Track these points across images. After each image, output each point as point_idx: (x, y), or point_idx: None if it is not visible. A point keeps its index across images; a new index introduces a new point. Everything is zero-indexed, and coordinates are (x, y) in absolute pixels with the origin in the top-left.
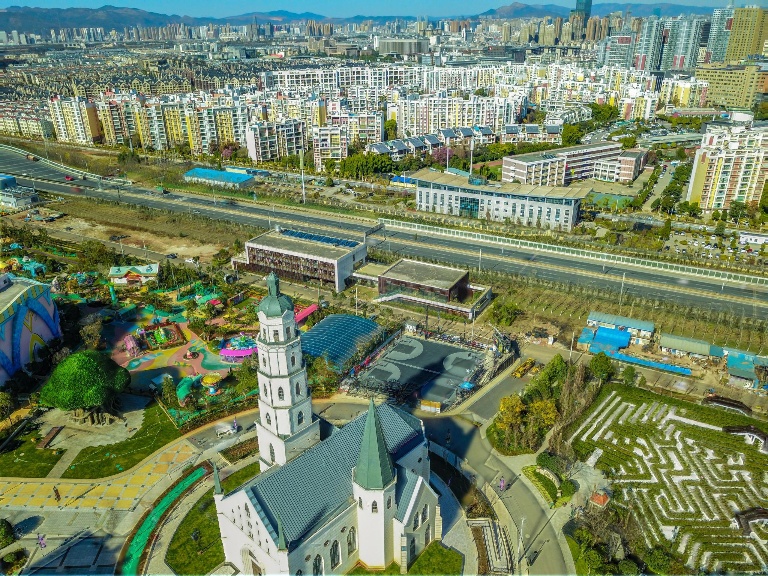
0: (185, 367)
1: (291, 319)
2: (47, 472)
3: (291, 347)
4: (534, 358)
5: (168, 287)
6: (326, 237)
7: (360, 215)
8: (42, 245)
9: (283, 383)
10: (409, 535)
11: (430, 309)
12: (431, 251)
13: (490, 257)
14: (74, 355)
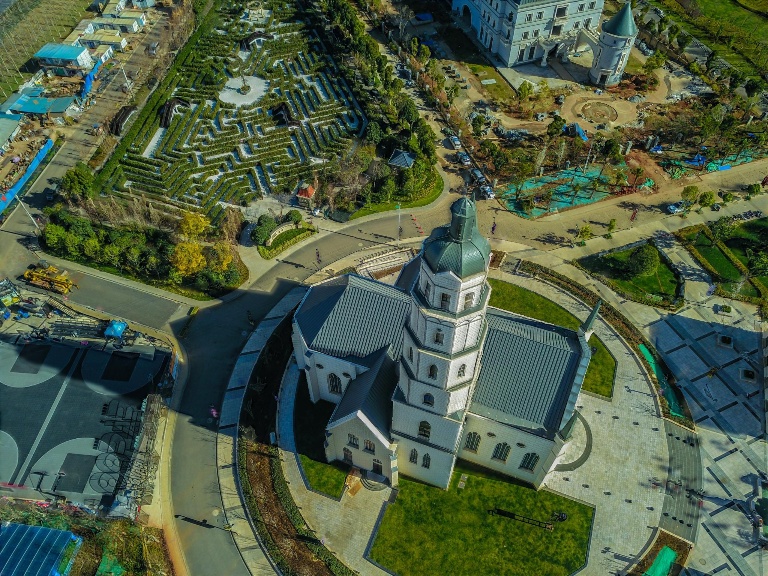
0: None
1: None
2: None
3: None
4: (12, 277)
5: None
6: None
7: None
8: None
9: None
10: None
11: None
12: None
13: None
14: None
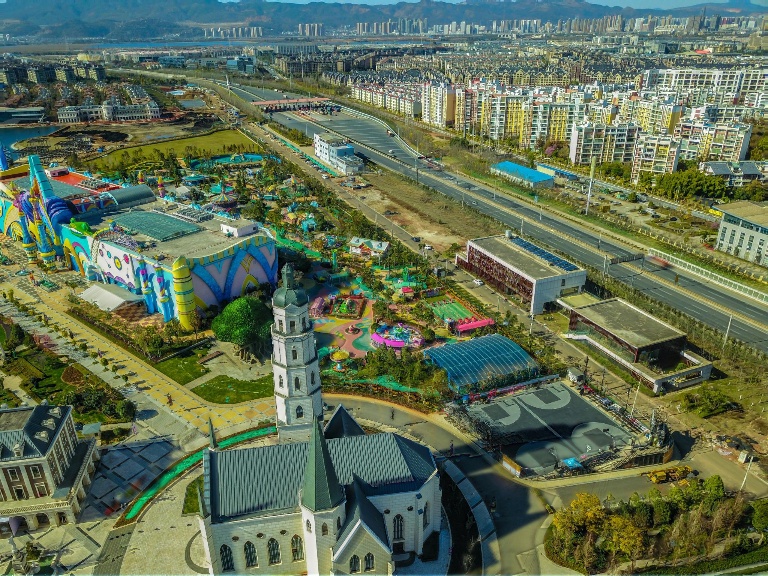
0: (340, 339)
1: (297, 314)
2: (187, 382)
3: (292, 341)
4: (700, 469)
5: (387, 265)
6: (549, 253)
7: (637, 240)
8: (331, 207)
9: (282, 372)
10: (342, 574)
11: (614, 364)
12: (687, 300)
13: (762, 328)
14: (241, 298)
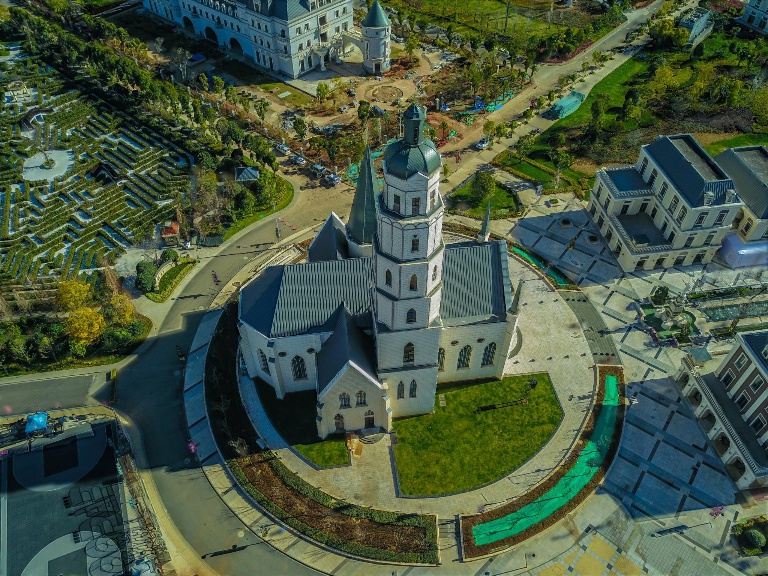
0: None
1: None
2: None
3: None
4: None
5: None
6: None
7: None
8: None
9: None
10: None
11: None
12: None
13: None
14: None
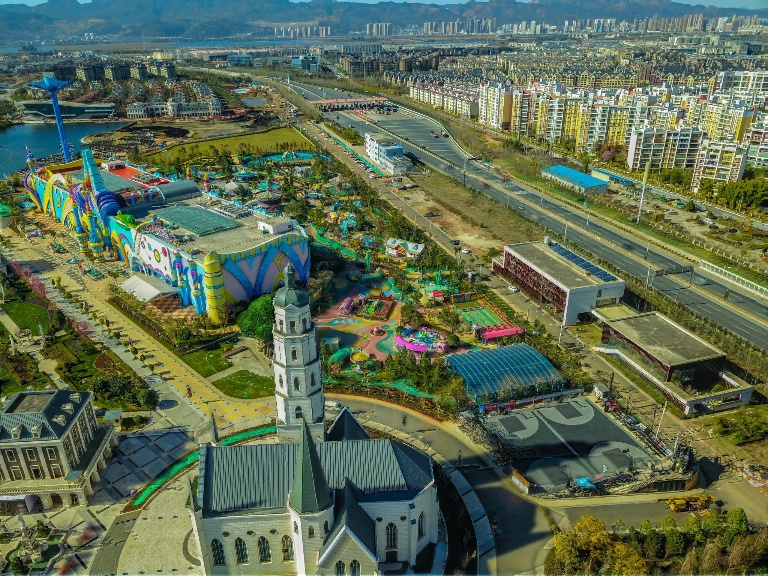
0: (364, 340)
1: (297, 315)
2: (209, 375)
3: (292, 341)
4: (726, 500)
5: None
6: (588, 262)
7: (690, 251)
8: (373, 207)
9: (282, 372)
10: None
11: (646, 381)
12: (736, 318)
13: None
14: (266, 295)
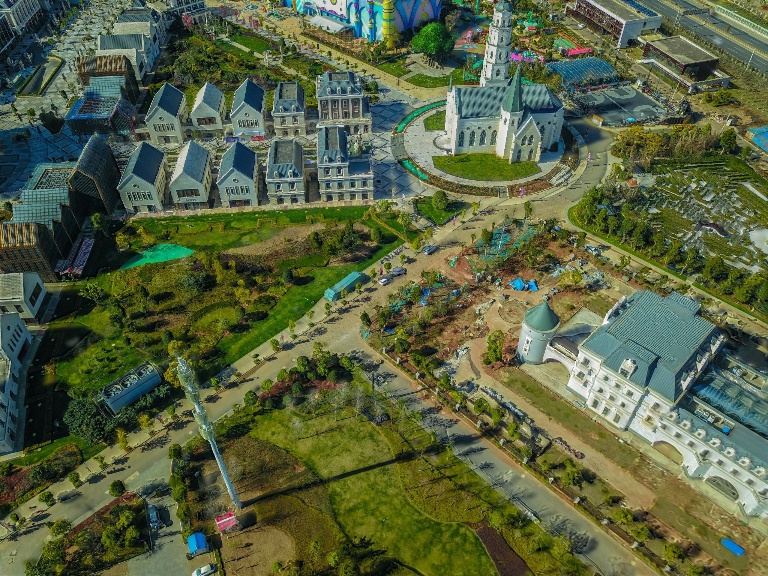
0: None
1: (507, 16)
2: (400, 76)
3: (503, 31)
4: None
5: (514, 11)
6: (638, 4)
7: None
8: None
9: (494, 49)
10: (518, 145)
11: (668, 77)
12: (731, 44)
13: None
14: (432, 23)
